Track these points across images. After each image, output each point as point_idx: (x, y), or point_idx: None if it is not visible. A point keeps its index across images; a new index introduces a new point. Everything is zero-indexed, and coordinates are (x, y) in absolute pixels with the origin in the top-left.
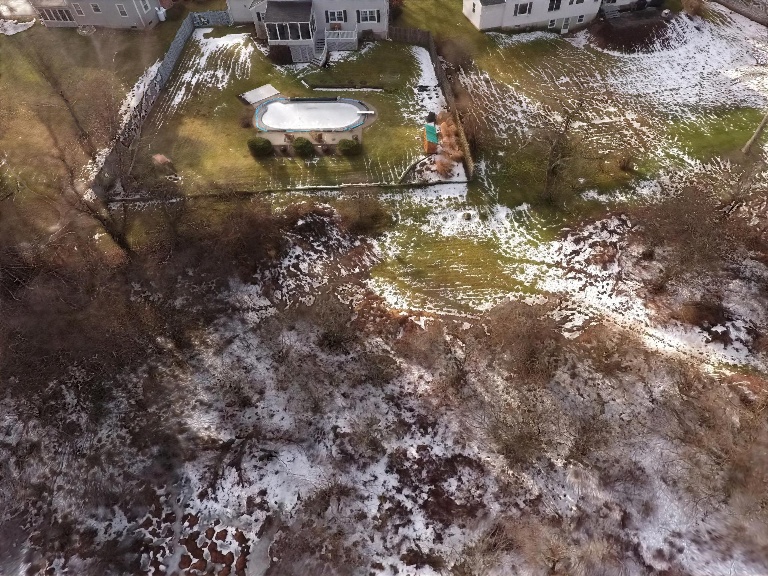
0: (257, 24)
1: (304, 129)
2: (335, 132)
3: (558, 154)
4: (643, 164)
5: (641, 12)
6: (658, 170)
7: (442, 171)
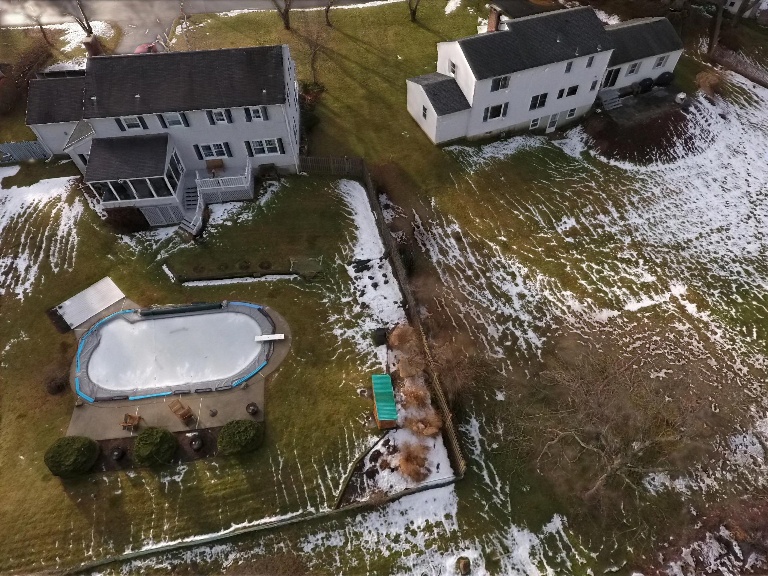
0: (84, 169)
1: (162, 390)
2: (217, 392)
3: (602, 421)
4: (723, 398)
5: (647, 96)
6: (748, 408)
7: (410, 472)
